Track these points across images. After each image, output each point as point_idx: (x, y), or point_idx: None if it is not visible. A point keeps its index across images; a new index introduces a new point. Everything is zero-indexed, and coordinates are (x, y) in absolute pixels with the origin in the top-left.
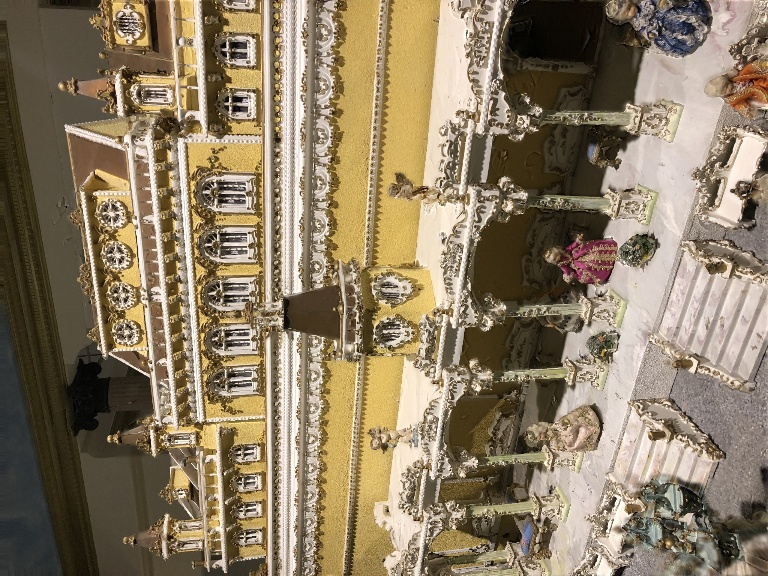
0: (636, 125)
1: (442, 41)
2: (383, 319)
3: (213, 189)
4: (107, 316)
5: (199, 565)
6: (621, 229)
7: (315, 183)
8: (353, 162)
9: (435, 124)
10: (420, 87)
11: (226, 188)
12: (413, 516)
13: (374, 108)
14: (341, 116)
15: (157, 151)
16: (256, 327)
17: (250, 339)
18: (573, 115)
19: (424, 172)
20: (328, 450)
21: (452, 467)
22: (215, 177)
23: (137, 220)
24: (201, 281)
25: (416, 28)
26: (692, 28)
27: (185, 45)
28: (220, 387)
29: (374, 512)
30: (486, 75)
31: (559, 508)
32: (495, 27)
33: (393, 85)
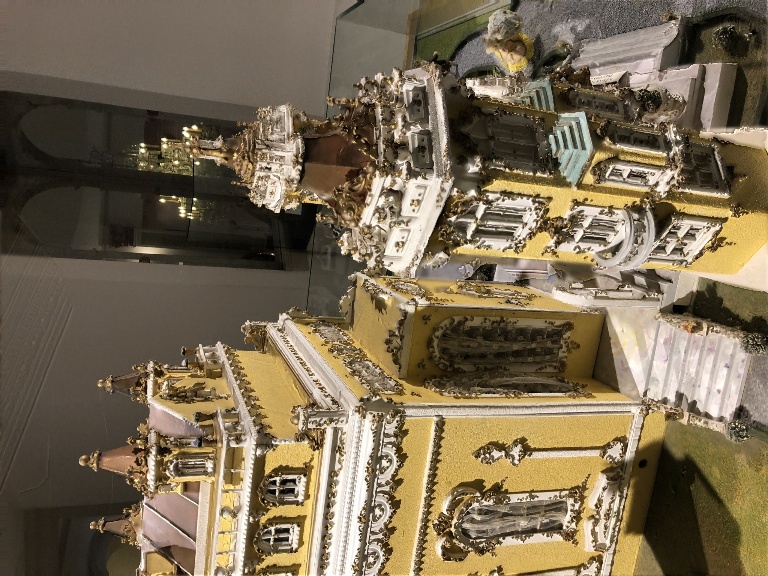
0: None
1: None
2: None
3: None
4: None
5: (189, 350)
6: None
7: None
8: None
9: None
10: None
11: None
12: None
13: None
14: None
15: None
16: None
17: None
18: None
19: None
20: None
21: None
22: None
23: None
24: None
25: None
26: None
27: None
28: None
29: None
30: None
31: None
32: None
33: None
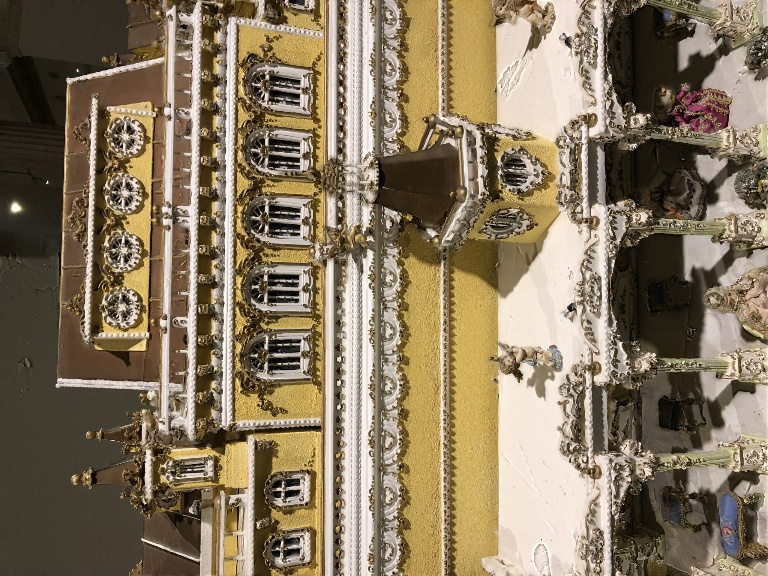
0: None
1: None
2: (507, 150)
3: (265, 80)
4: (98, 281)
5: None
6: (723, 73)
7: (384, 69)
8: (422, 52)
9: None
10: None
11: (278, 86)
12: (584, 469)
13: None
14: (408, 1)
15: (205, 25)
16: (309, 271)
17: (300, 290)
18: None
19: (496, 64)
20: (410, 465)
21: (628, 358)
22: (268, 68)
23: (171, 108)
24: (243, 199)
25: None
26: None
27: None
28: (257, 368)
29: (486, 568)
30: None
31: (762, 451)
32: None
33: None
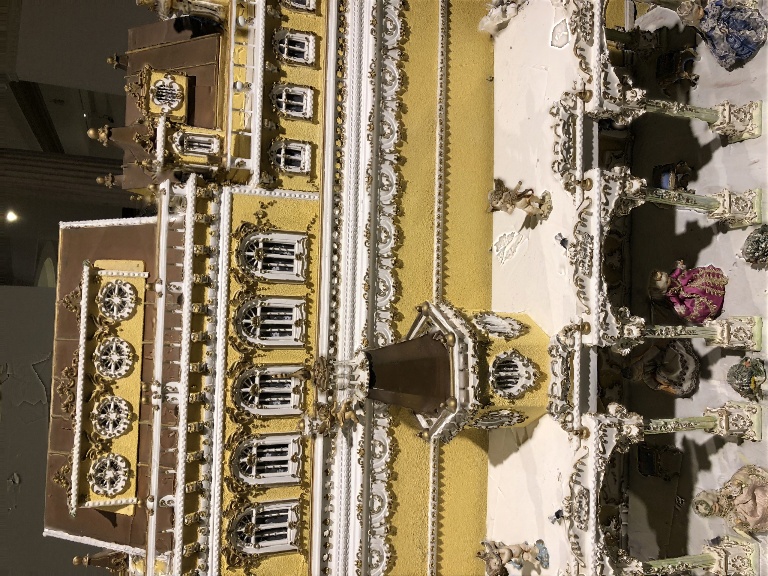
0: (726, 118)
1: (505, 84)
2: (499, 354)
3: (258, 249)
4: (86, 449)
5: None
6: (720, 250)
7: (379, 236)
8: (418, 215)
9: (507, 162)
10: (479, 141)
11: (272, 251)
12: None
13: (438, 156)
14: (405, 164)
15: (199, 198)
16: (298, 440)
17: (289, 459)
18: (670, 103)
19: (493, 225)
20: None
21: (614, 572)
22: (261, 235)
23: (163, 285)
24: (233, 372)
25: (471, 85)
26: (755, 26)
27: (242, 89)
28: (244, 541)
29: None
30: (592, 52)
31: None
32: (597, 4)
33: (454, 136)
